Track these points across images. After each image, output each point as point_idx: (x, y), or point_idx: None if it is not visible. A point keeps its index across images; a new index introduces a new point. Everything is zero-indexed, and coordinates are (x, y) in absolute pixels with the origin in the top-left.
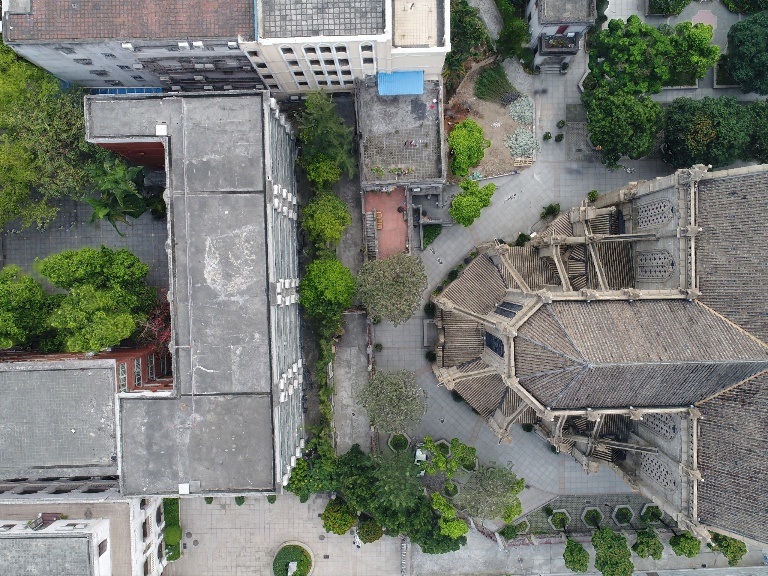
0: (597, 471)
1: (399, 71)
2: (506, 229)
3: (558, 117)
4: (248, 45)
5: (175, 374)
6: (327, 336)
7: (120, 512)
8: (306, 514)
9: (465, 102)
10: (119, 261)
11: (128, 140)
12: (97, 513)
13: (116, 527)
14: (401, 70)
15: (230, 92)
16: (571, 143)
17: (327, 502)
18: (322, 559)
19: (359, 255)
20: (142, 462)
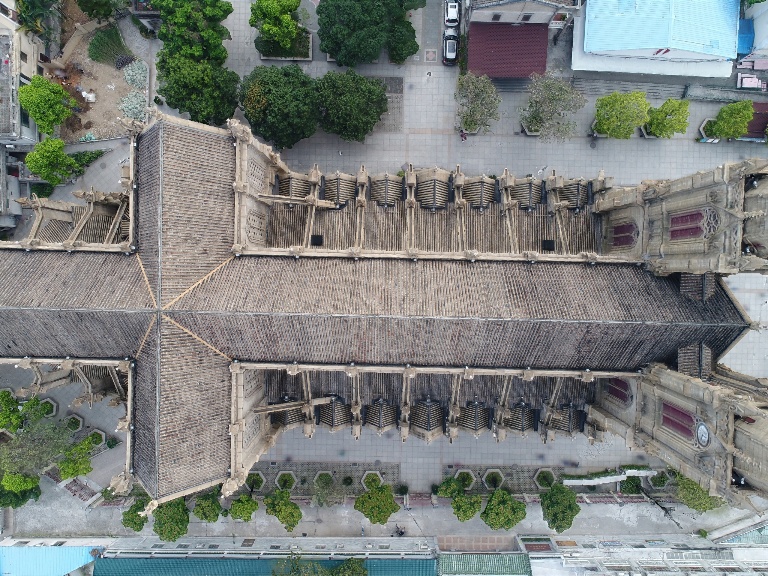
0: None
1: None
2: None
3: None
4: None
5: None
6: None
7: None
8: None
9: (79, 63)
10: None
11: None
12: None
13: None
14: None
15: None
16: None
17: None
18: None
19: None
20: None
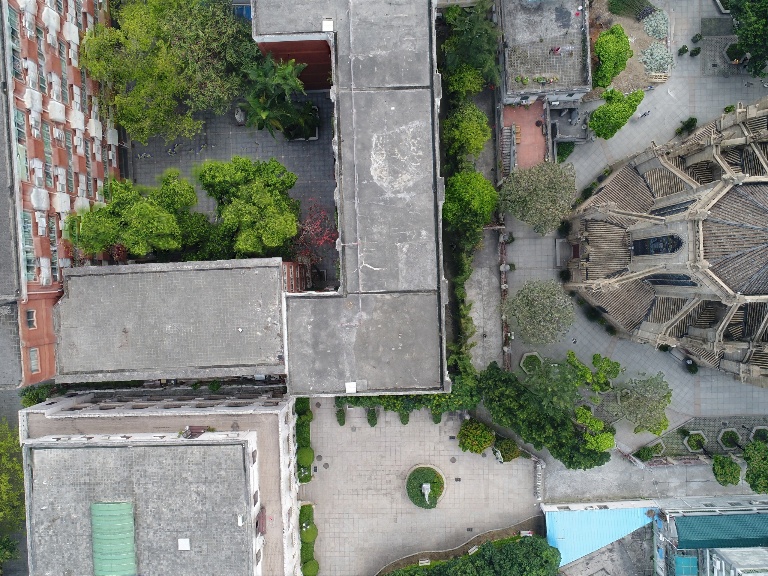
0: (759, 376)
1: None
2: (640, 146)
3: (693, 31)
4: None
5: (342, 272)
6: (468, 250)
7: (267, 424)
8: (437, 436)
9: (598, 17)
10: (270, 169)
11: (294, 37)
12: (244, 426)
13: (263, 439)
14: None
15: None
16: (706, 58)
17: (458, 424)
18: (453, 482)
19: (490, 174)
20: (308, 361)
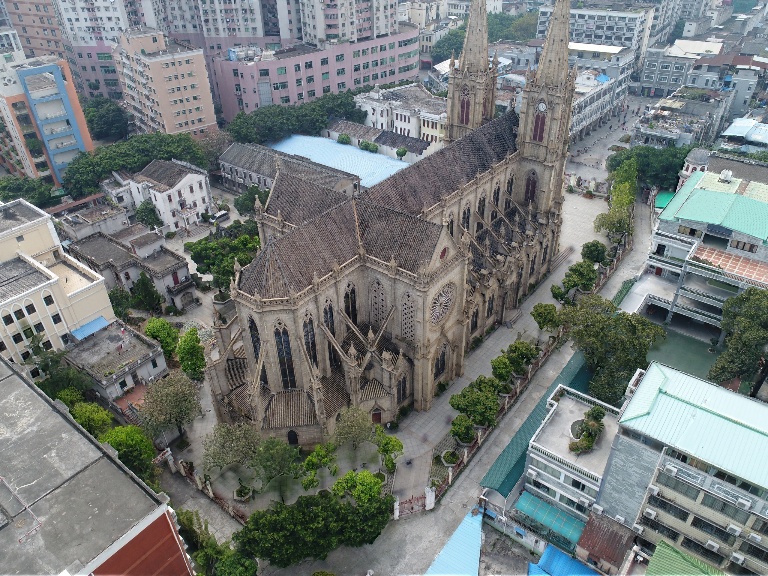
0: (390, 355)
1: (85, 324)
2: None
3: None
4: None
5: None
6: (148, 477)
7: None
8: None
9: None
10: None
11: None
12: None
13: None
14: (86, 323)
15: None
16: None
17: None
18: None
19: None
20: None
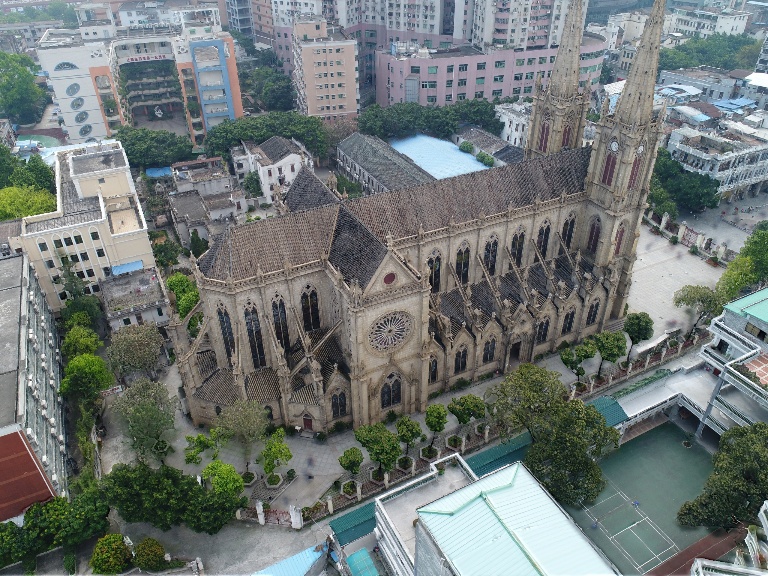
0: (319, 366)
1: (126, 263)
2: None
3: None
4: (15, 241)
5: None
6: (85, 403)
7: None
8: None
9: None
10: None
11: None
12: None
13: None
14: (127, 263)
15: (0, 257)
16: None
17: None
18: None
19: None
20: None
